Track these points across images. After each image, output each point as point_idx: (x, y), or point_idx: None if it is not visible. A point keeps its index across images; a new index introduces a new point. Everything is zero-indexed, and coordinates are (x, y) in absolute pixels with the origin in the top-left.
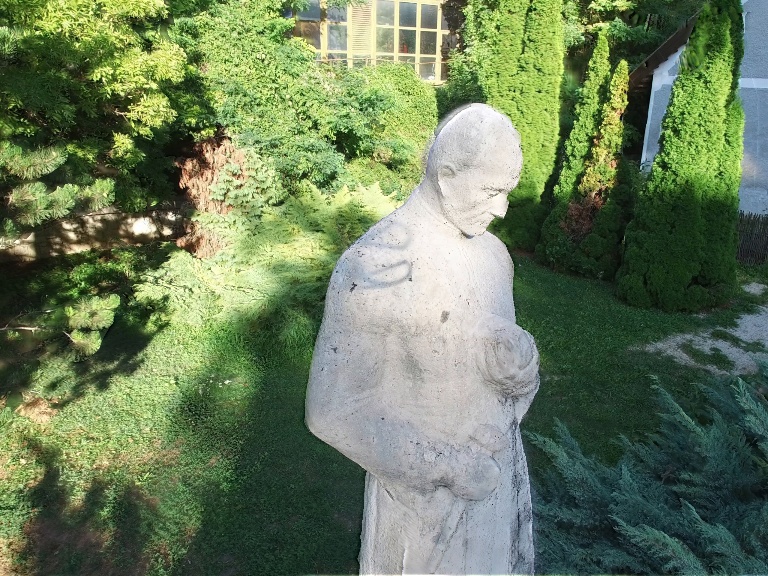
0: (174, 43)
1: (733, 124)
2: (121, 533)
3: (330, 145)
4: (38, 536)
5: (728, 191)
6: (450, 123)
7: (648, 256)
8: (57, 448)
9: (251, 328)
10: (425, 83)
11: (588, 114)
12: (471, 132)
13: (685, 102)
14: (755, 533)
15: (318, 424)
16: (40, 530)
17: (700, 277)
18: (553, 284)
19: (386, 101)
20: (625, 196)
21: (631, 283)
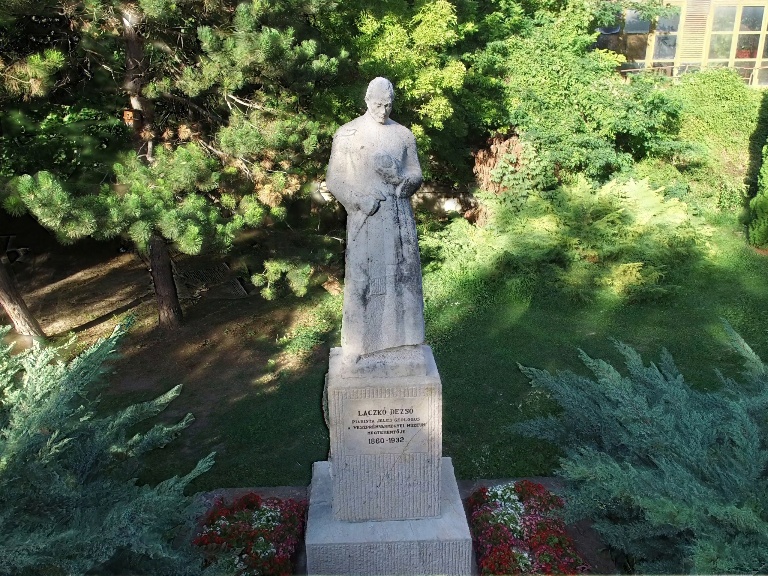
0: None
1: None
2: None
3: (609, 144)
4: (318, 353)
5: None
6: None
7: None
8: None
9: (492, 276)
10: (752, 88)
11: None
12: None
13: None
14: None
15: None
16: (320, 351)
17: None
18: None
19: (670, 104)
20: None
21: None
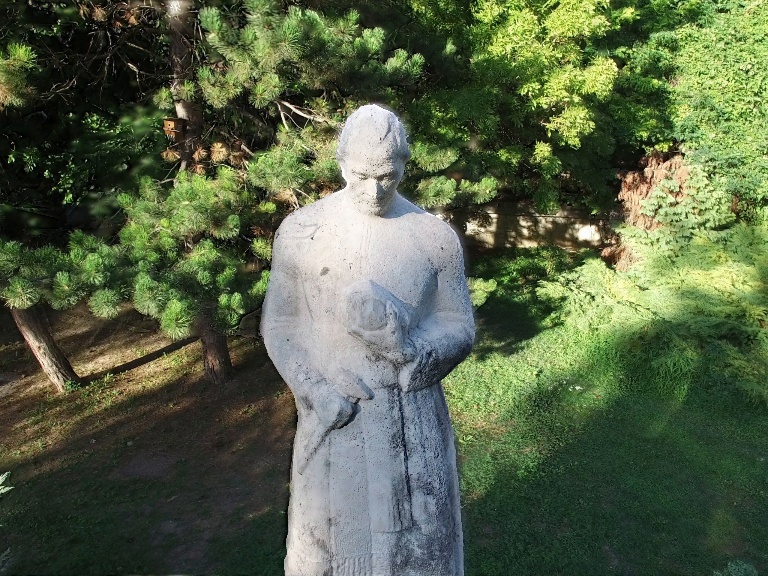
0: (609, 58)
1: None
2: None
3: None
4: None
5: None
6: None
7: None
8: None
9: (632, 347)
10: None
11: None
12: None
13: None
14: None
15: None
16: None
17: None
18: None
19: None
20: None
21: None
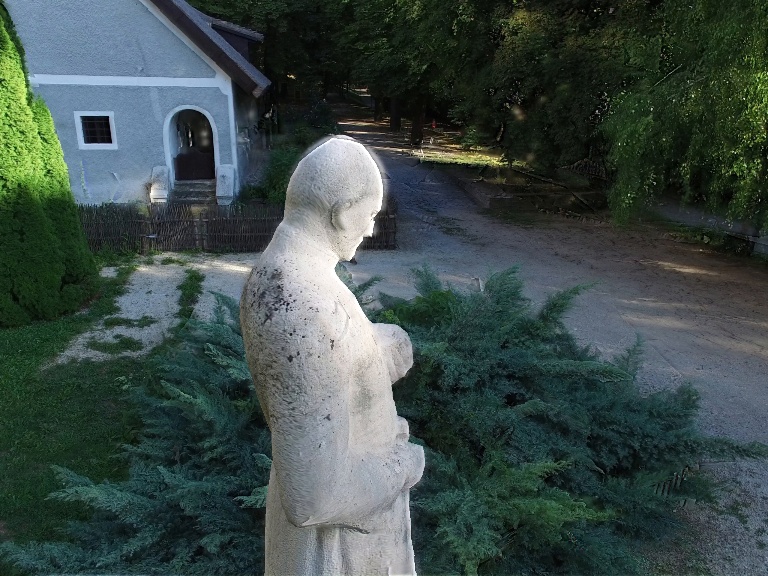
0: None
1: (43, 122)
2: None
3: None
4: None
5: (62, 188)
6: (327, 159)
7: (7, 271)
8: None
9: None
10: None
11: None
12: (359, 165)
13: None
14: None
15: None
16: None
17: (67, 276)
18: None
19: None
20: None
21: None
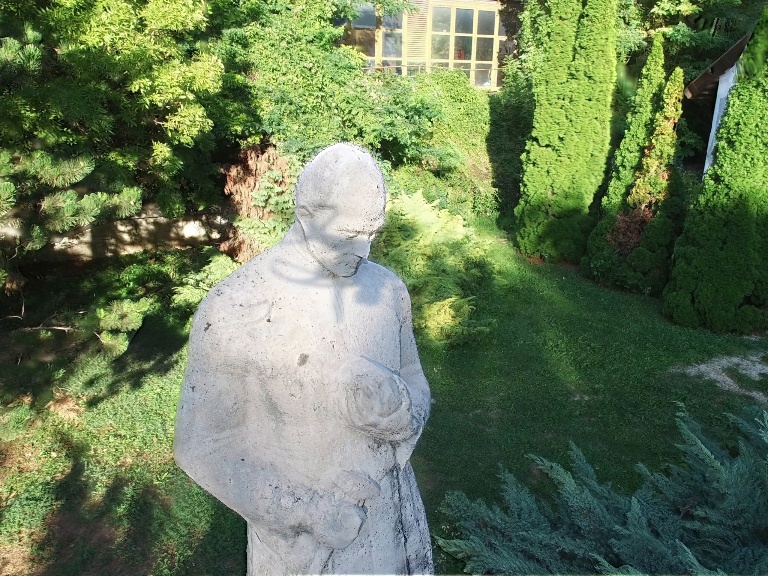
0: (213, 55)
1: None
2: (134, 531)
3: (374, 153)
4: (58, 529)
5: None
6: None
7: (697, 273)
8: (86, 444)
9: None
10: (478, 90)
11: (640, 123)
12: (324, 174)
13: (741, 112)
14: None
15: (179, 463)
16: (60, 523)
17: (753, 297)
18: (596, 299)
19: (432, 109)
20: (676, 209)
21: (678, 301)
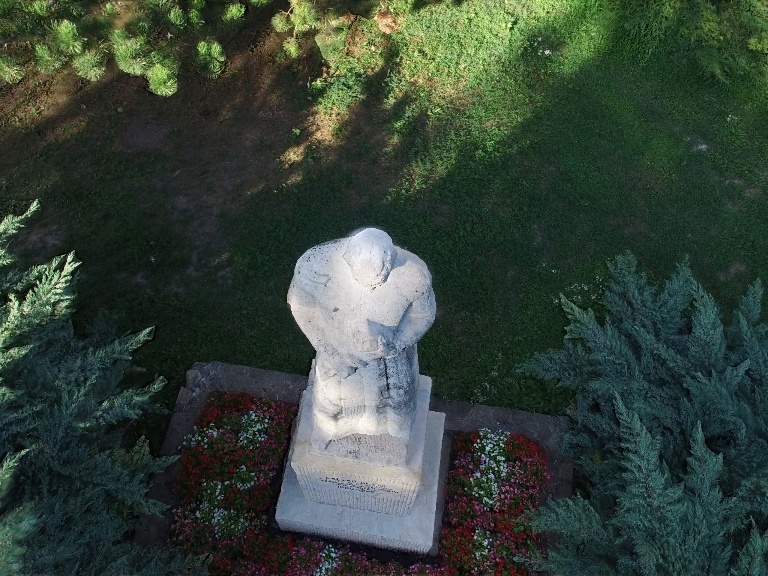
0: None
1: None
2: (399, 147)
3: None
4: (354, 118)
5: None
6: None
7: None
8: (398, 49)
9: None
10: None
11: None
12: (353, 256)
13: None
14: (762, 480)
15: None
16: (357, 114)
17: None
18: None
19: None
20: None
21: None
